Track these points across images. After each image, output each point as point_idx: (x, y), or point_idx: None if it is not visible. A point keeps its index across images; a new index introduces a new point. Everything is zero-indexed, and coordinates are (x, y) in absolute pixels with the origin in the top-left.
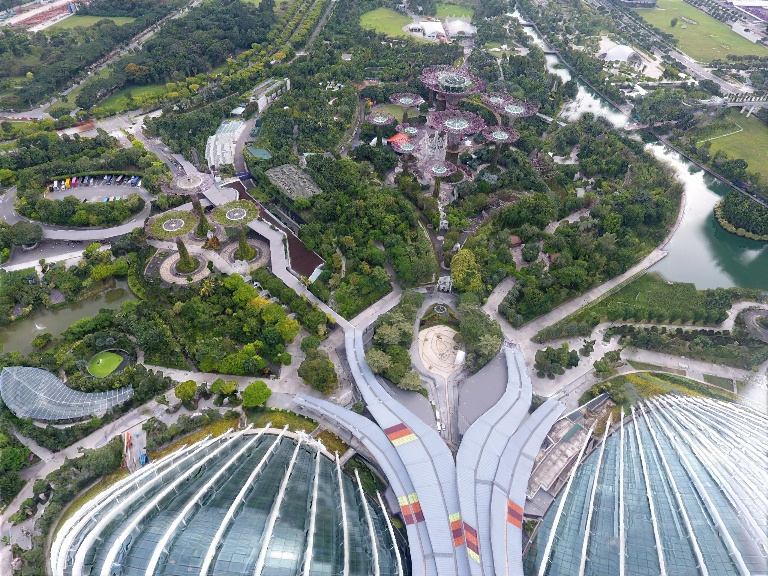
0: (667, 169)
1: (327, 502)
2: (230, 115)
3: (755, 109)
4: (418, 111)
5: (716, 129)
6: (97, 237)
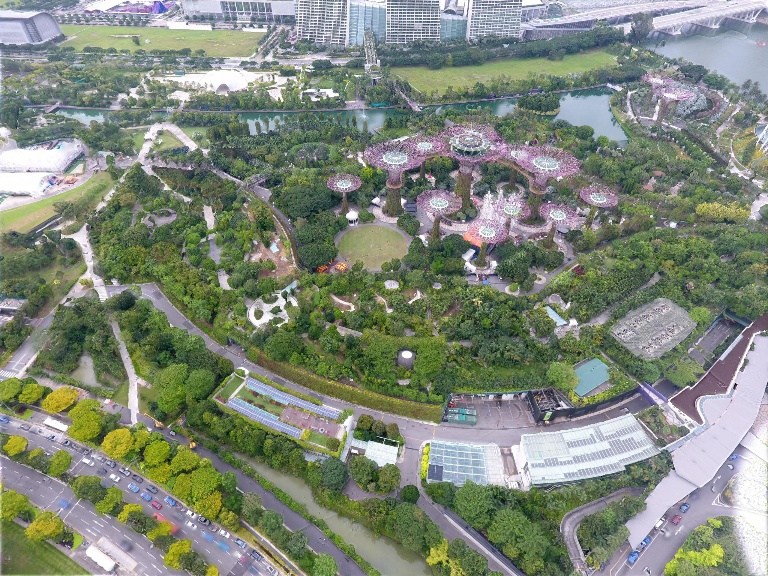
0: None
1: None
2: None
3: None
4: (361, 225)
5: None
6: None
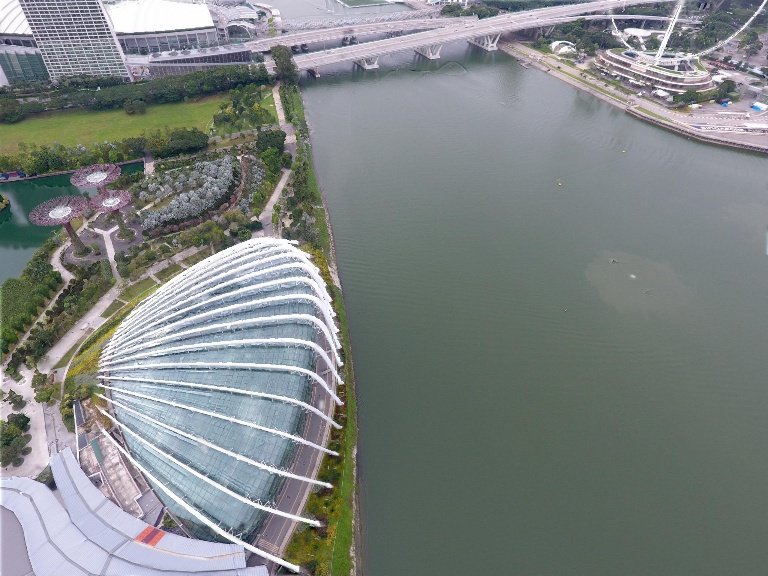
0: None
1: None
2: None
3: None
4: None
5: None
6: None
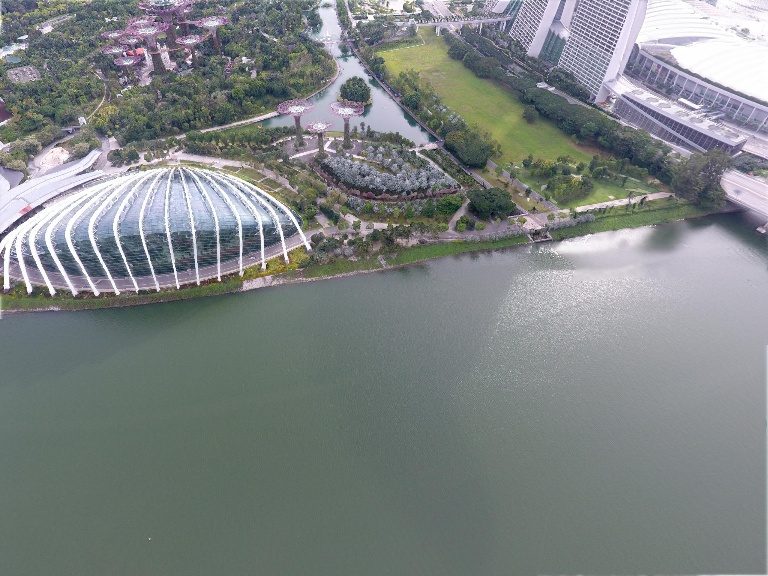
0: (328, 66)
1: None
2: (18, 41)
3: (450, 31)
4: None
5: (400, 43)
6: None
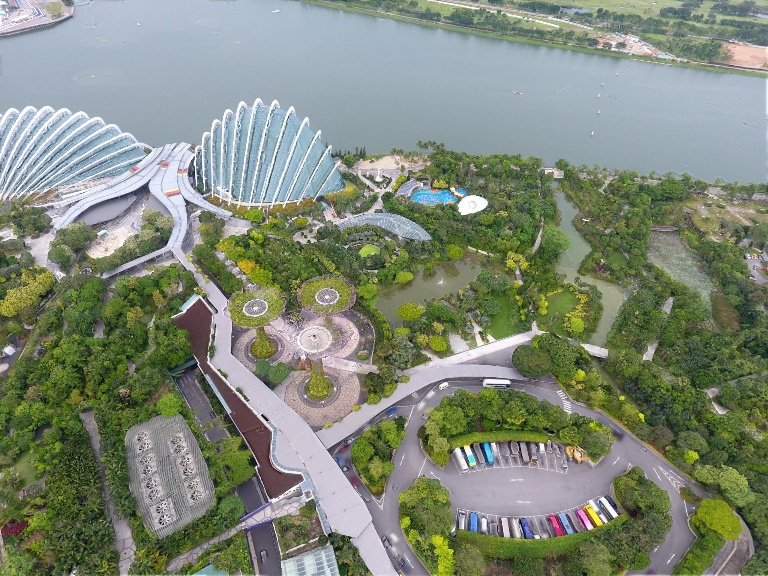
0: None
1: (219, 153)
2: None
3: None
4: None
5: None
6: (448, 367)
